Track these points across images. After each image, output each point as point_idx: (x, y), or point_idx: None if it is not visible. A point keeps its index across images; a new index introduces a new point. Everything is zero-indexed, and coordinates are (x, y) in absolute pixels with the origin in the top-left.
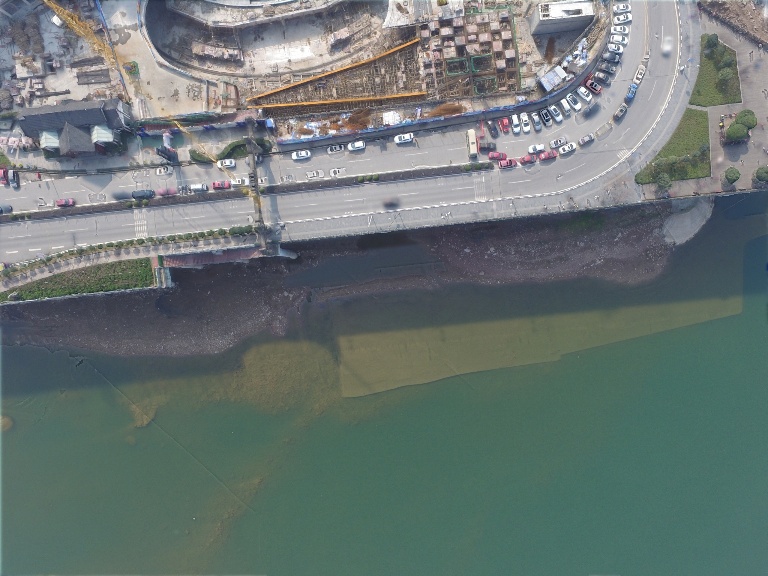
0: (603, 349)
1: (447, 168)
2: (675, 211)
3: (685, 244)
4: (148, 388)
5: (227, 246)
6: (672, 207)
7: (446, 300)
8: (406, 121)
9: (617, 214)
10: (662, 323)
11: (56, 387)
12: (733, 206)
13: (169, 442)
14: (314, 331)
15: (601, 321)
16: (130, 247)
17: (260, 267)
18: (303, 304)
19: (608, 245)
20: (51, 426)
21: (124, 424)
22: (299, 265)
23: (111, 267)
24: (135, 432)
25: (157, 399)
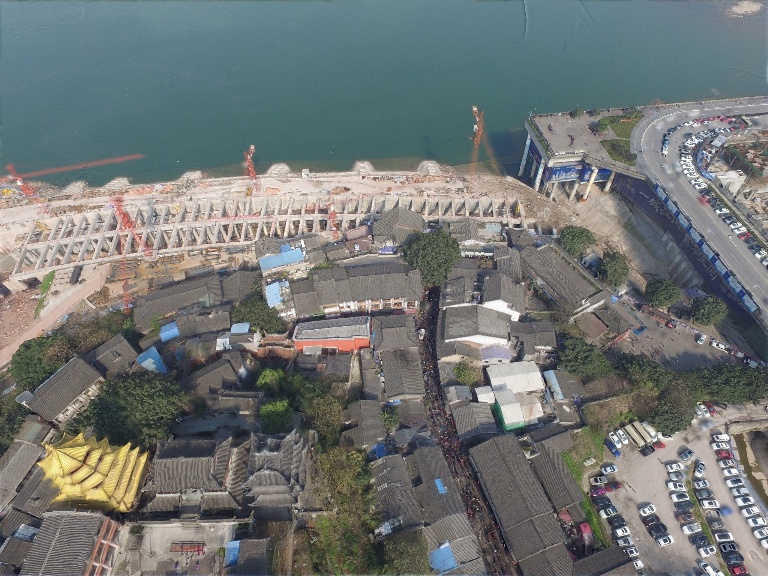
0: None
1: (752, 115)
2: None
3: None
4: None
5: None
6: None
7: None
8: None
9: None
10: None
11: None
12: None
13: None
14: None
15: None
16: None
17: None
18: None
19: None
20: None
21: None
22: None
23: None
24: None
25: None
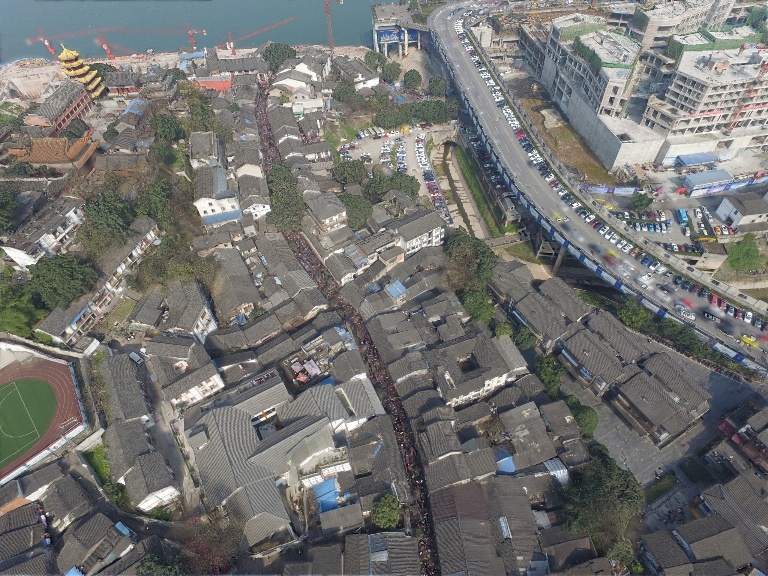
0: None
1: (517, 1)
2: None
3: None
4: None
5: None
6: None
7: None
8: (535, 7)
9: None
10: None
11: None
12: None
13: None
14: None
15: None
16: None
17: None
18: None
19: None
20: None
21: None
22: None
23: None
24: None
25: None
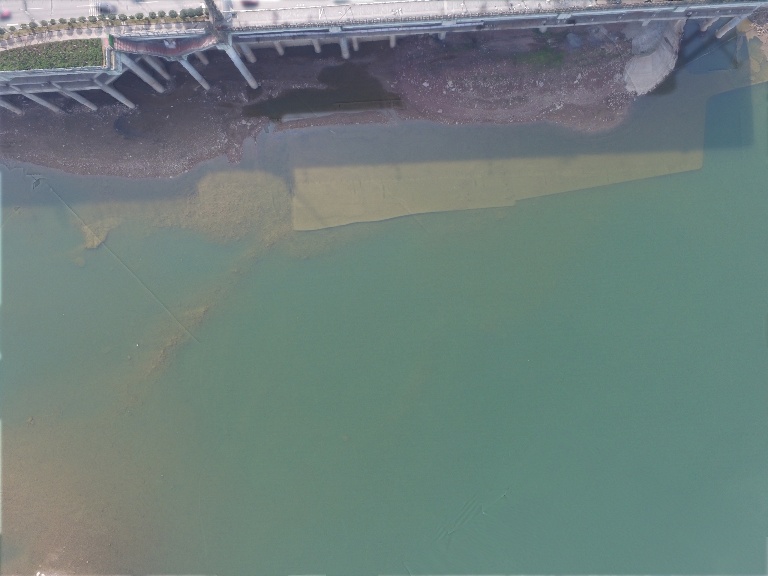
0: (559, 197)
1: None
2: (636, 53)
3: (647, 95)
4: (101, 210)
5: (178, 30)
6: (632, 47)
7: (403, 139)
8: None
9: (576, 50)
10: (620, 173)
11: (12, 208)
12: (697, 60)
13: (118, 266)
14: (270, 162)
15: (558, 168)
16: (83, 27)
17: (220, 94)
18: (260, 134)
19: (568, 88)
20: (3, 242)
21: (75, 244)
22: (259, 95)
23: (62, 45)
24: (85, 254)
25: (109, 221)
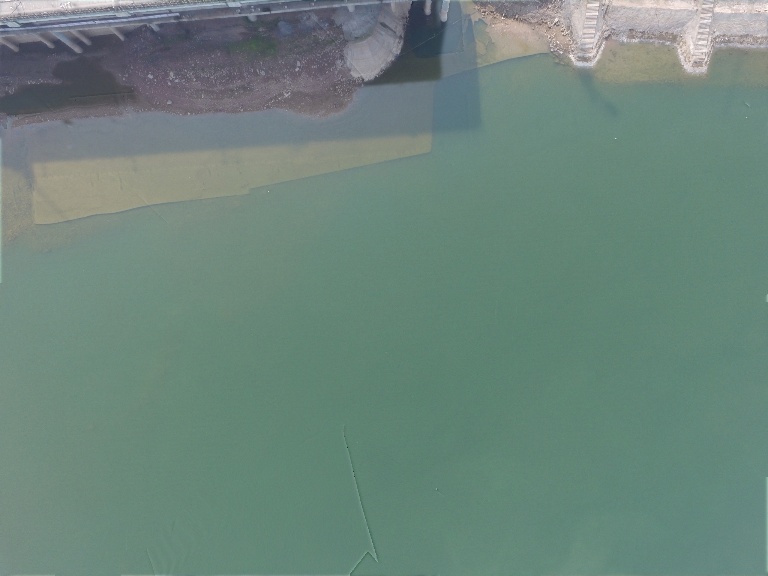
0: (292, 184)
1: None
2: (349, 39)
3: (374, 81)
4: None
5: None
6: (344, 33)
7: (138, 131)
8: None
9: (287, 38)
10: (350, 159)
11: None
12: (423, 44)
13: None
14: (10, 158)
15: (290, 156)
16: None
17: None
18: None
19: (291, 76)
20: None
21: None
22: None
23: None
24: None
25: None
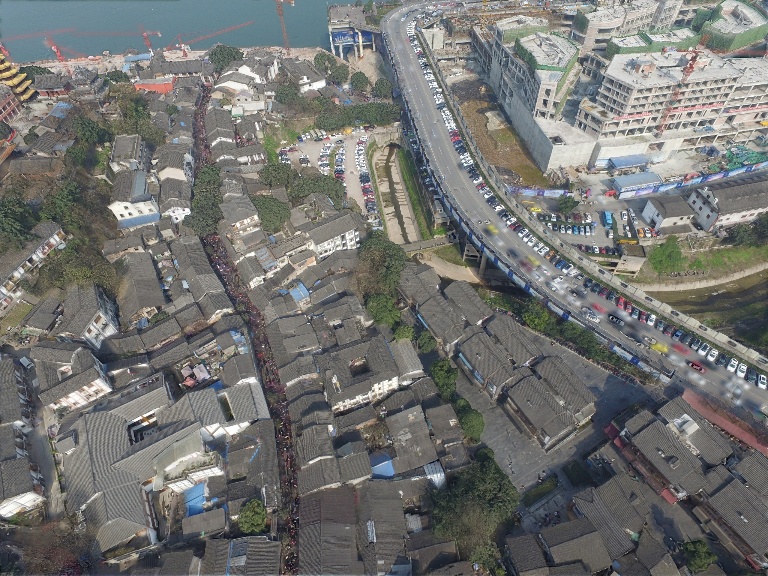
0: None
1: (472, 3)
2: None
3: None
4: None
5: None
6: None
7: None
8: None
9: None
10: None
11: None
12: None
13: None
14: None
15: None
16: None
17: None
18: None
19: None
20: None
21: None
22: None
23: None
24: None
25: None
